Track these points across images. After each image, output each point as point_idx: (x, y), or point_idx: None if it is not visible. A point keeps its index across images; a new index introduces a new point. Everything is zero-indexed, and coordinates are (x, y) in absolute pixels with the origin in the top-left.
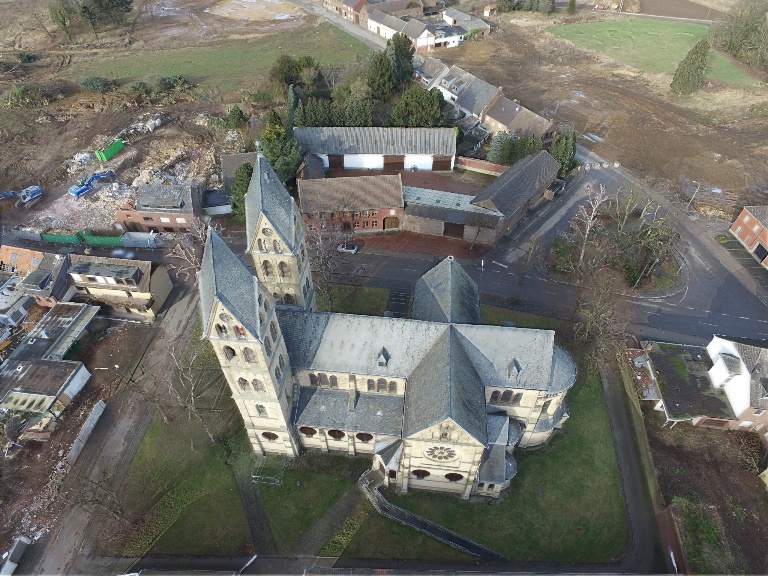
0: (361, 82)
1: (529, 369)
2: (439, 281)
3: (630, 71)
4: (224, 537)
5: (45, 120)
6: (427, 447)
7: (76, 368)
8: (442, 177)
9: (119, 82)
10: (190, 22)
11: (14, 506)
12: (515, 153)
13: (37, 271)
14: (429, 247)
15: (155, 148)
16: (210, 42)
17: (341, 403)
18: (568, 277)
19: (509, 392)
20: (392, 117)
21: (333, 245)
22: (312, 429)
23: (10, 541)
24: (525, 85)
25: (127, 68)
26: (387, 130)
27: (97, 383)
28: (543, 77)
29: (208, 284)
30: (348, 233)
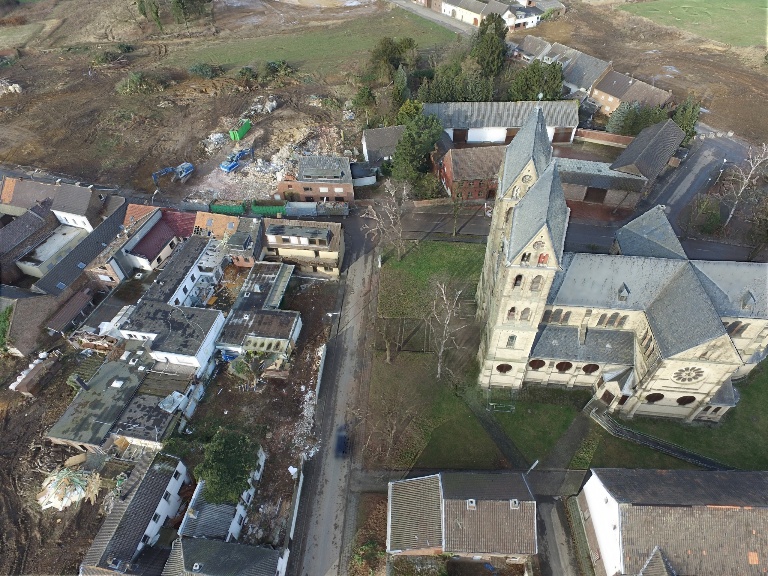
0: (471, 60)
1: (762, 300)
2: (653, 227)
3: (717, 45)
4: (478, 454)
5: (167, 104)
6: (680, 368)
7: (297, 316)
8: (563, 148)
9: (223, 68)
10: (266, 11)
11: (280, 430)
12: (638, 123)
13: (237, 233)
14: (573, 211)
15: (278, 128)
16: (293, 29)
17: (571, 337)
18: (716, 236)
19: (736, 323)
20: (509, 92)
21: (480, 211)
22: (542, 362)
23: (290, 458)
24: (615, 61)
25: (224, 55)
26: (511, 104)
27: (310, 331)
28: (630, 53)
29: (531, 214)
30: (491, 200)
